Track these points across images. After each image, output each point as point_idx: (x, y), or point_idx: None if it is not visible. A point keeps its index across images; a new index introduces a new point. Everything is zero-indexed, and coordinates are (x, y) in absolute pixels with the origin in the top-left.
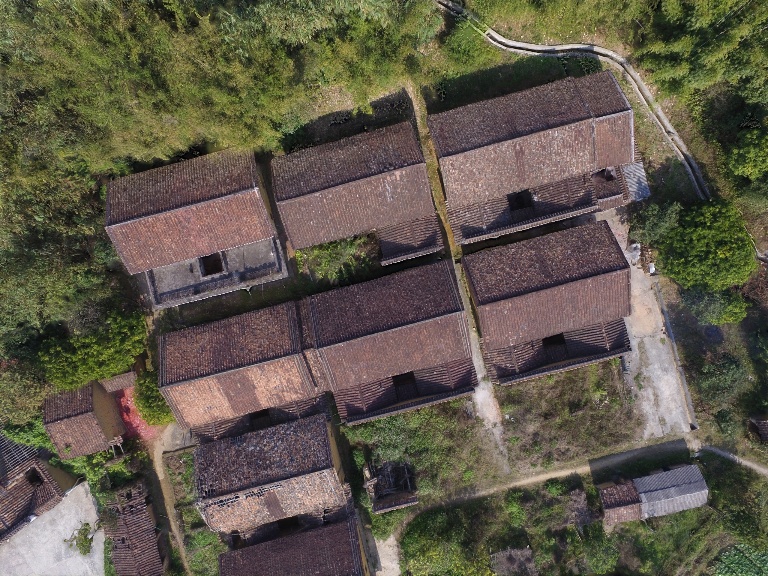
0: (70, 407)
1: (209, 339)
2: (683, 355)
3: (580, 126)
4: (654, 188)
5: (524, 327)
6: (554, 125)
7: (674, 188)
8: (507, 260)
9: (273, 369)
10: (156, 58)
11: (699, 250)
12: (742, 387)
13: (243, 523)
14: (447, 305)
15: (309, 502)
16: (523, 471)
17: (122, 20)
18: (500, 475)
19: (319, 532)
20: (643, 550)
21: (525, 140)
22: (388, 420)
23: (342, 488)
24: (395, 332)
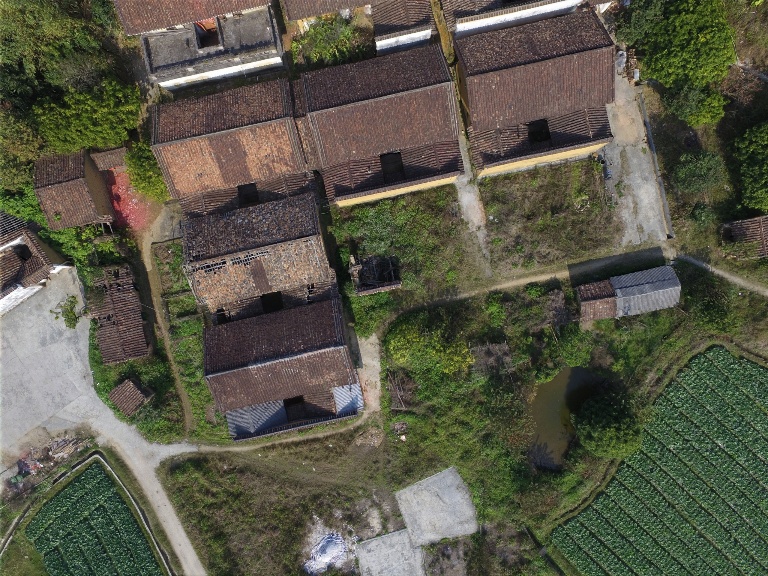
0: (61, 174)
1: (203, 108)
2: (663, 164)
3: None
4: None
5: (511, 107)
6: None
7: None
8: (497, 42)
9: (265, 134)
10: None
11: (682, 39)
12: (718, 196)
13: (229, 295)
14: (437, 77)
15: (294, 275)
16: (504, 273)
17: None
18: (482, 278)
19: (303, 309)
20: (617, 355)
21: None
22: (375, 216)
23: (327, 262)
24: (385, 101)
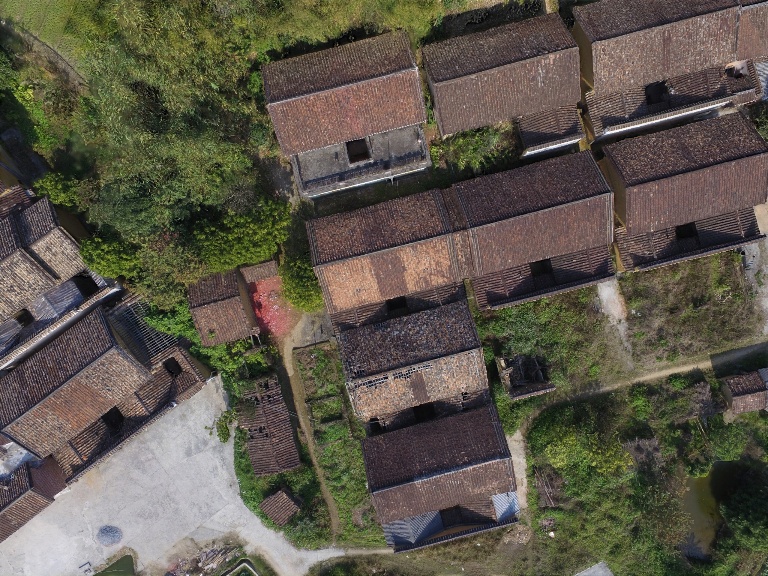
0: (216, 292)
1: (358, 223)
2: None
3: (726, 14)
4: None
5: (666, 212)
6: (702, 12)
7: None
8: (649, 148)
9: (425, 250)
10: None
11: None
12: None
13: (387, 407)
14: (595, 188)
15: (453, 385)
16: (647, 366)
17: None
18: (624, 371)
19: (460, 417)
20: (762, 443)
21: (674, 27)
22: (518, 314)
23: (486, 371)
24: (545, 213)
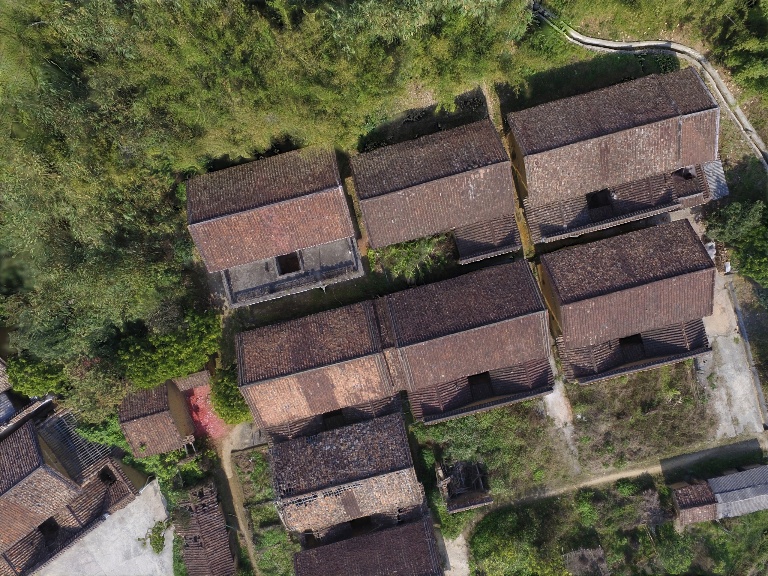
0: (145, 406)
1: (287, 338)
2: (757, 355)
3: (667, 124)
4: (730, 186)
5: (605, 326)
6: (641, 123)
7: (751, 186)
8: (588, 259)
9: (353, 368)
10: (257, 55)
11: None
12: None
13: (319, 522)
14: (529, 304)
15: (386, 501)
16: (594, 471)
17: (222, 17)
18: (570, 475)
19: (394, 531)
20: (714, 550)
21: (611, 138)
22: (459, 419)
23: (419, 488)
24: (477, 331)
